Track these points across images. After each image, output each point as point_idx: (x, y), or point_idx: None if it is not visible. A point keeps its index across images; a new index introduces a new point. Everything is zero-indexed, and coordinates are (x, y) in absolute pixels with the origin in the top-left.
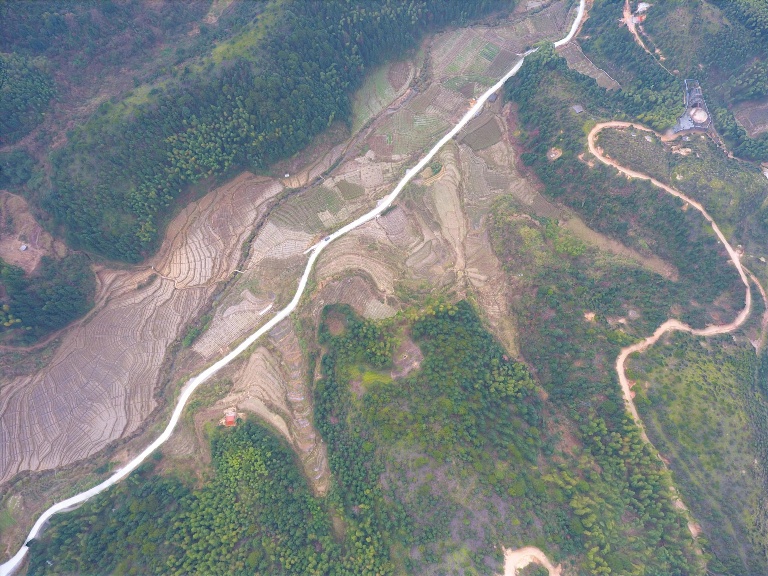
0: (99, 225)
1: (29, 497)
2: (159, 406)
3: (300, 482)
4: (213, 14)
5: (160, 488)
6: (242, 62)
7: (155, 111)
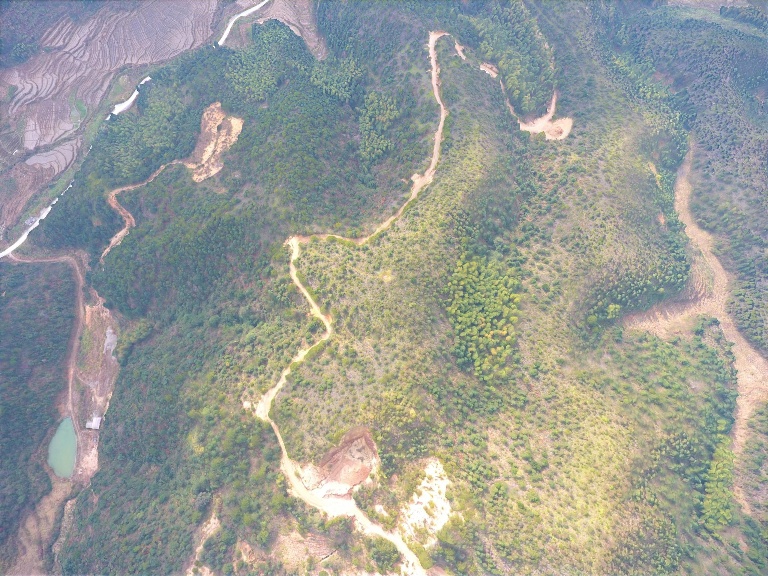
0: None
1: (133, 77)
2: (214, 33)
3: None
4: None
5: (221, 48)
6: None
7: None
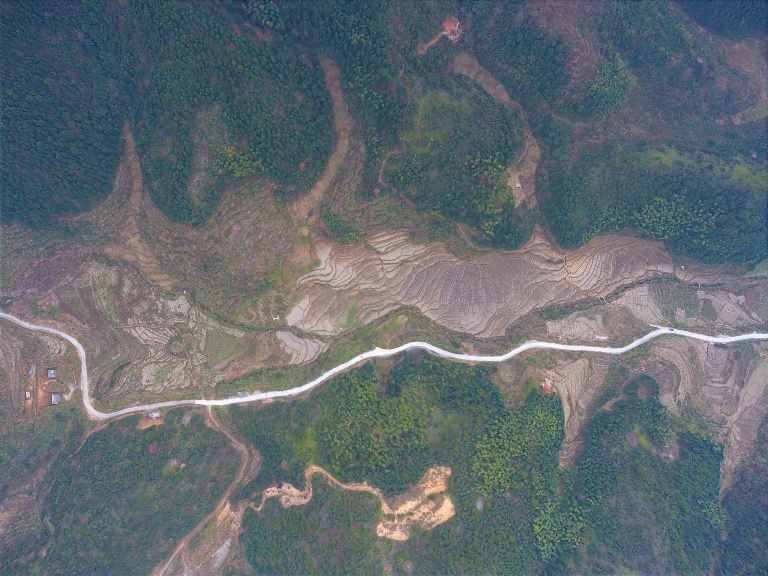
0: (571, 212)
1: (411, 323)
2: (505, 337)
3: (558, 454)
4: (741, 117)
5: (496, 393)
6: (749, 194)
7: (669, 177)
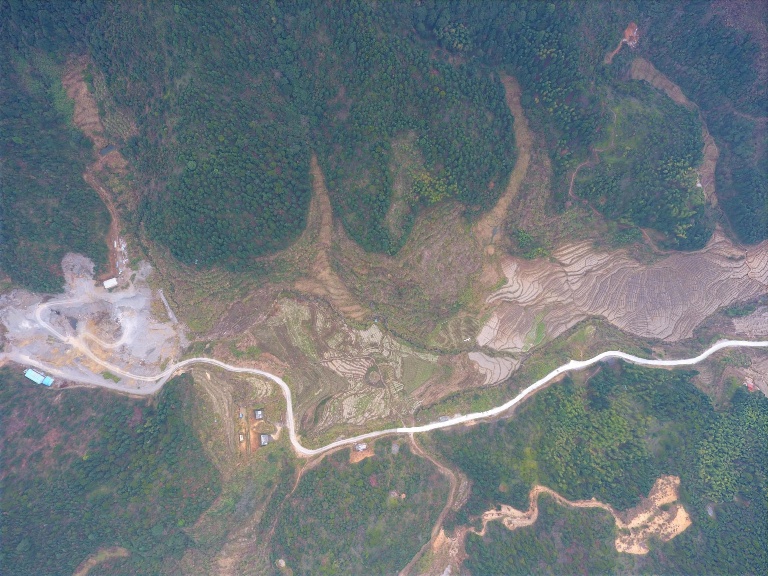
0: (757, 208)
1: (599, 333)
2: (693, 338)
3: None
4: None
5: (704, 396)
6: None
7: None
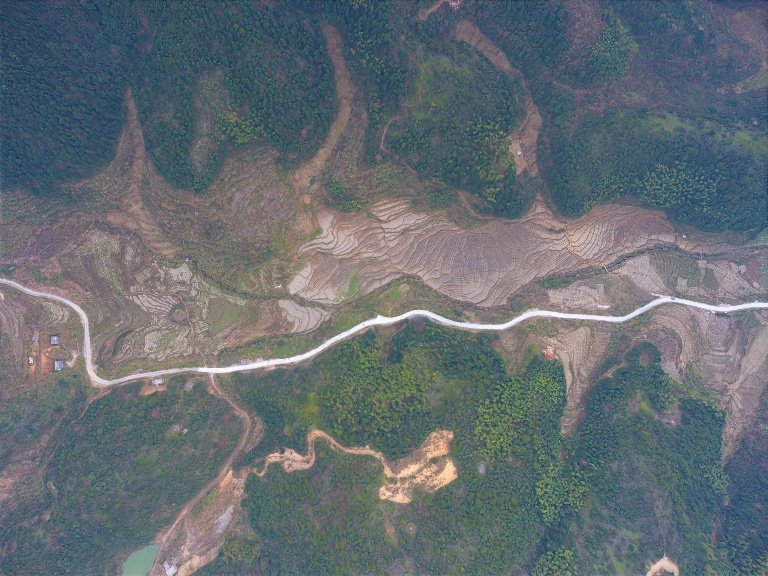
0: (572, 180)
1: (413, 292)
2: (506, 305)
3: None
4: (742, 86)
5: (497, 359)
6: (750, 159)
7: (670, 143)
